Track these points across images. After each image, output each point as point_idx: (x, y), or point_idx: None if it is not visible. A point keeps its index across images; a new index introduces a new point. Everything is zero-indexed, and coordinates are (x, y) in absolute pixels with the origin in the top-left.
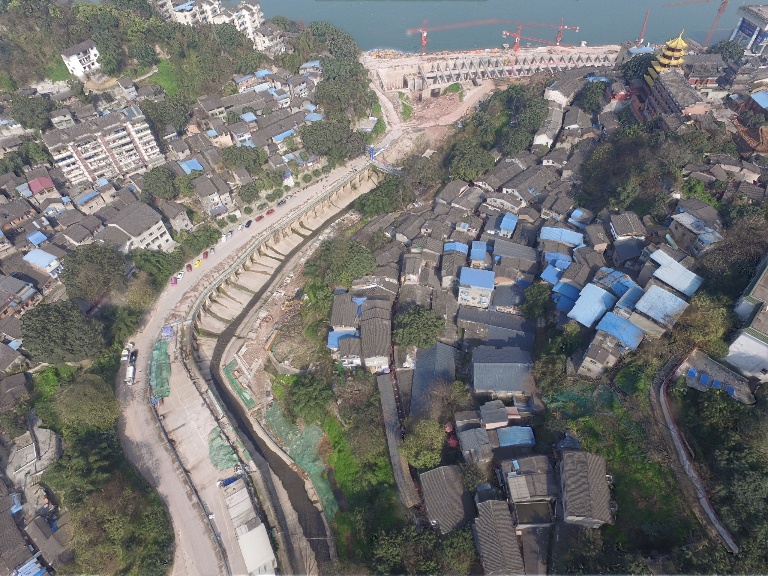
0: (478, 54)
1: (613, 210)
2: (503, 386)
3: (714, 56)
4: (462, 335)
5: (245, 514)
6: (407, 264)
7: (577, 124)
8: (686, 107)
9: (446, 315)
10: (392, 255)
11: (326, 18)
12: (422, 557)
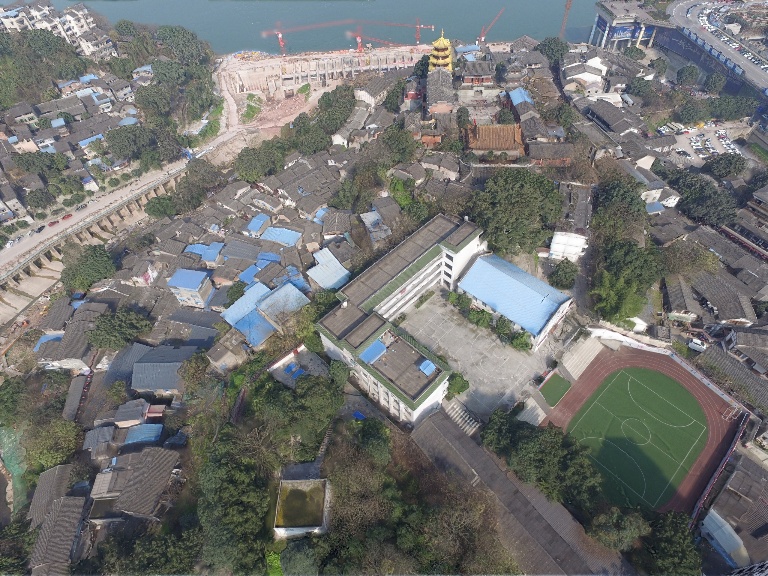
0: (341, 54)
1: (346, 209)
2: (159, 385)
3: (534, 53)
4: None
5: None
6: (135, 267)
7: (374, 124)
8: (430, 106)
9: (161, 316)
10: None
11: (213, 20)
12: (1, 554)
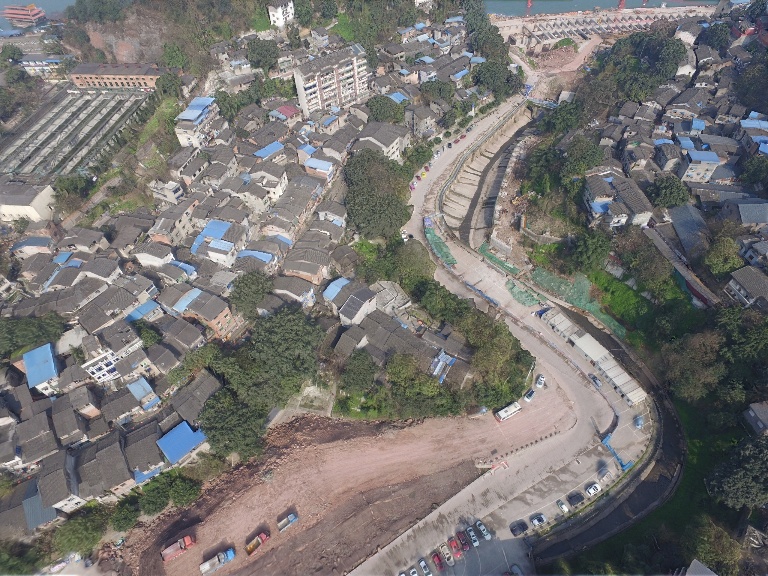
0: (573, 15)
1: None
2: (764, 219)
3: None
4: (697, 200)
5: (570, 328)
6: (636, 153)
7: (712, 57)
8: None
9: None
10: (607, 153)
11: None
12: None
